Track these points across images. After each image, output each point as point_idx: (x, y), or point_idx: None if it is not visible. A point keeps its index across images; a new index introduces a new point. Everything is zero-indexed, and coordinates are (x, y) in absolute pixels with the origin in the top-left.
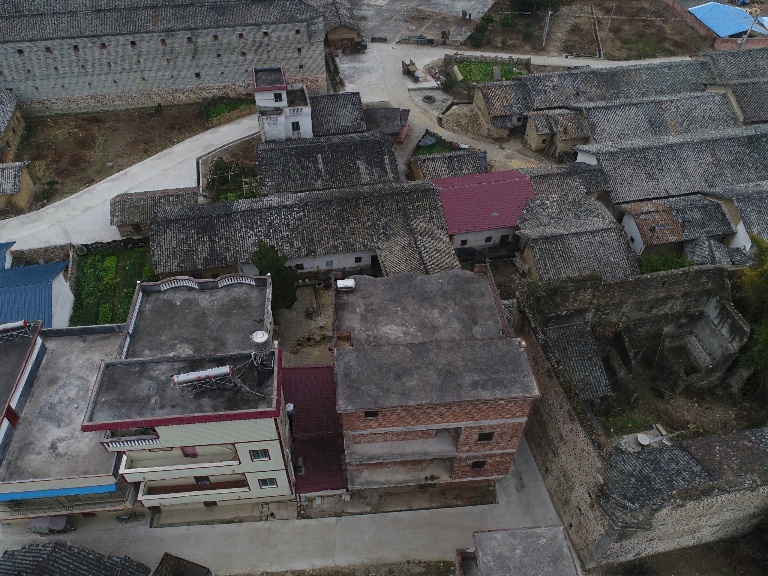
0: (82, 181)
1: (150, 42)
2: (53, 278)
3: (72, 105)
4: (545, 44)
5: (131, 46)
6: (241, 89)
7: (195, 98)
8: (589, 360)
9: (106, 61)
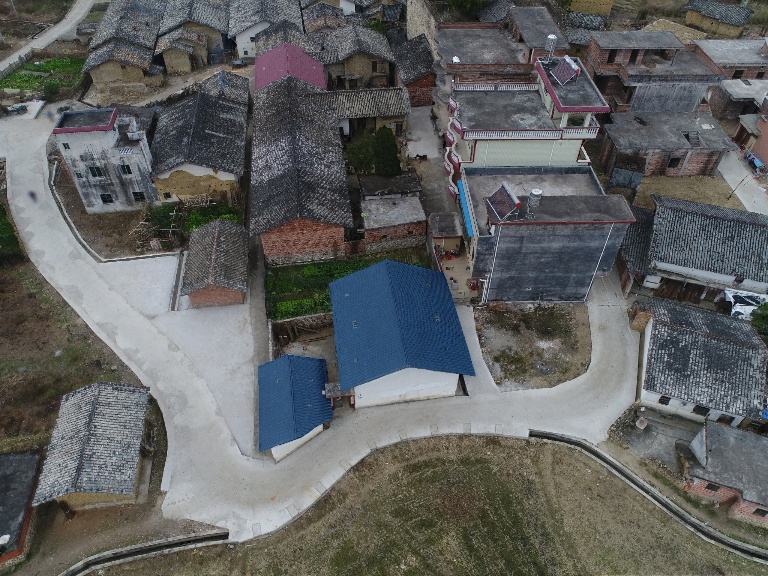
0: (92, 374)
1: None
2: (379, 263)
3: None
4: None
5: None
6: None
7: None
8: None
9: None
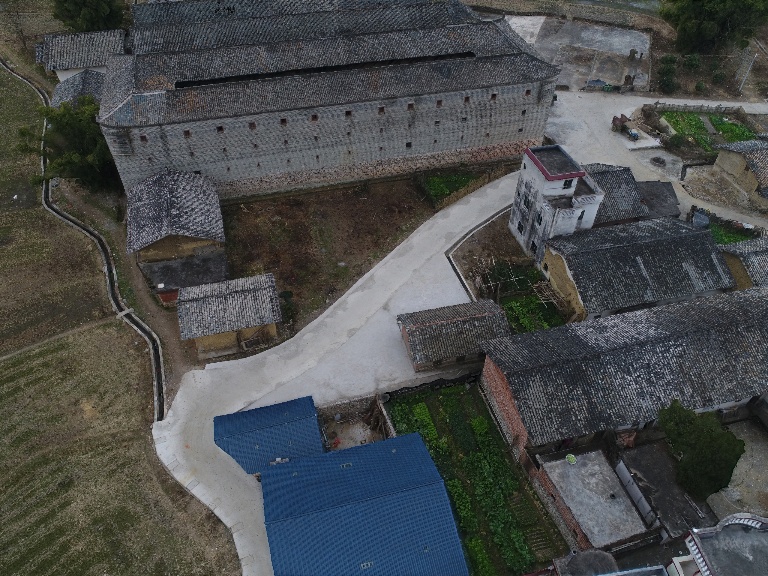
0: (322, 290)
1: (367, 111)
2: None
3: (263, 185)
4: (738, 87)
5: (345, 116)
6: (450, 157)
7: (399, 170)
8: None
9: (313, 135)
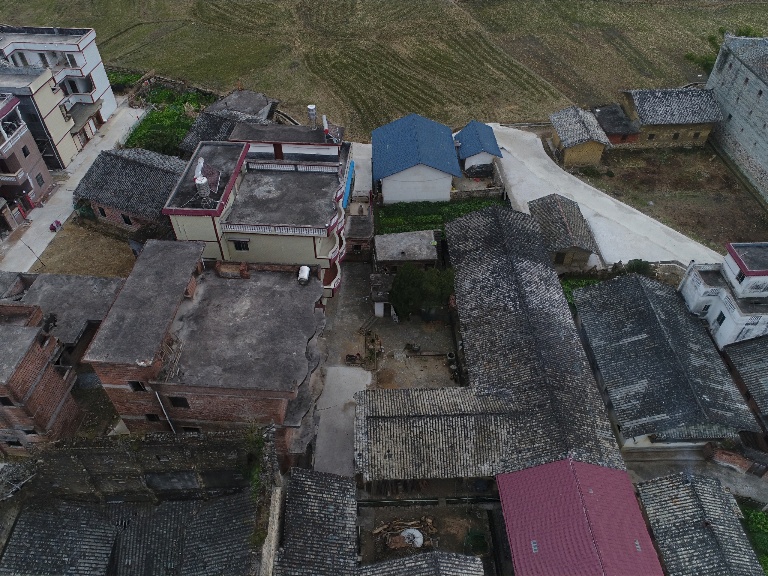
0: (617, 189)
1: None
2: (426, 164)
3: (747, 164)
4: None
5: None
6: None
7: None
8: (220, 573)
9: None
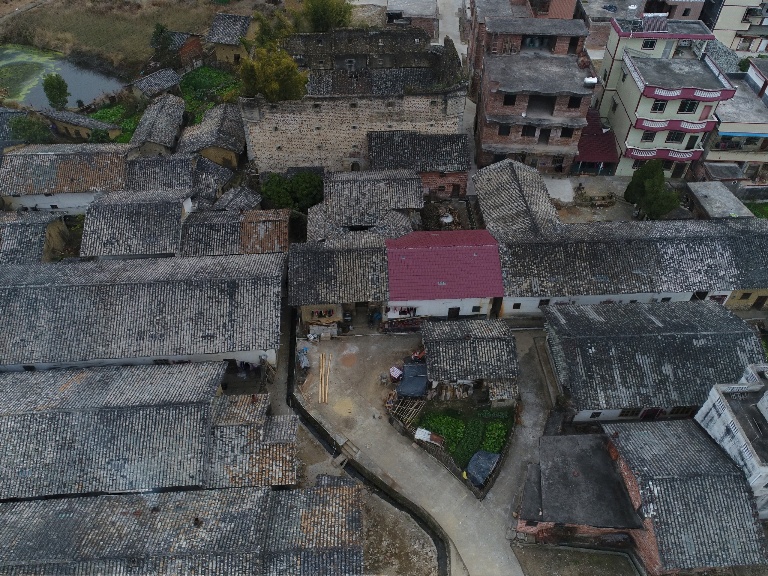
0: None
1: None
2: None
3: None
4: None
5: None
6: None
7: None
8: None
9: None
